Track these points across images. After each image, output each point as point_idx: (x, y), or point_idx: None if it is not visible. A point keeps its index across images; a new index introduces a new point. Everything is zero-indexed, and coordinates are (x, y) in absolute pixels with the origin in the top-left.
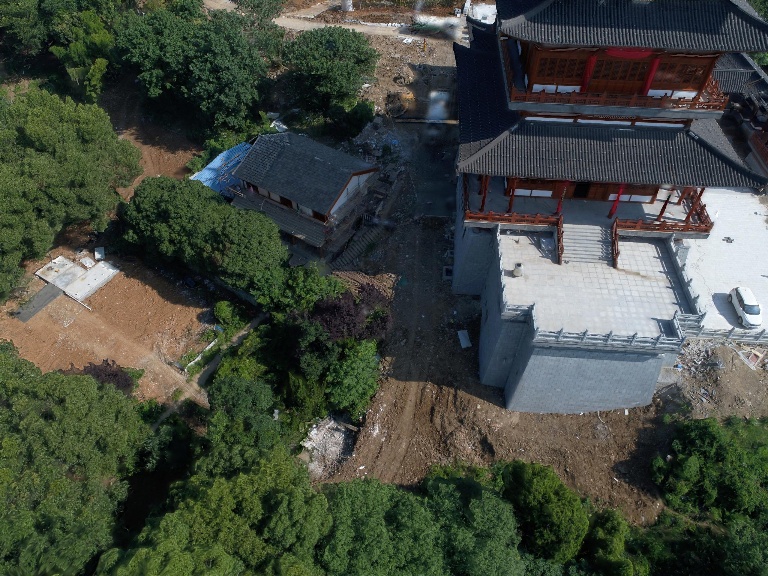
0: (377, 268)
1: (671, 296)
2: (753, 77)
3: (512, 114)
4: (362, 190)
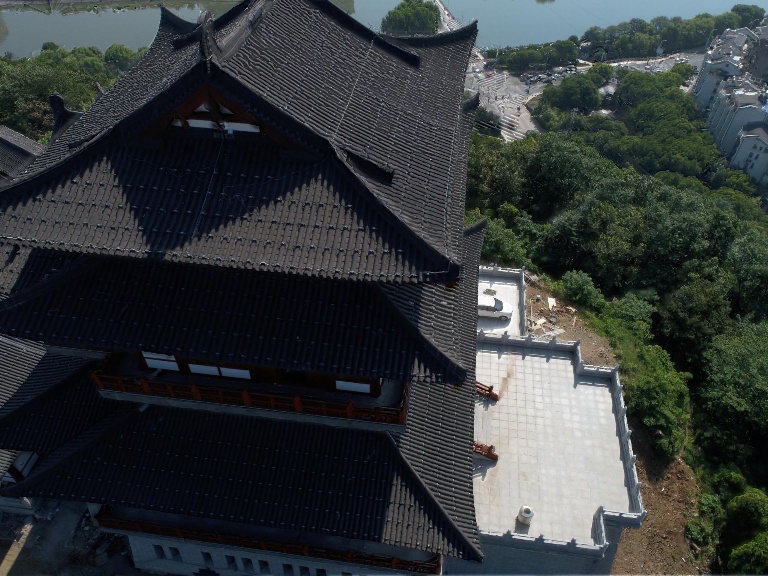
0: None
1: (537, 360)
2: None
3: (342, 434)
4: None
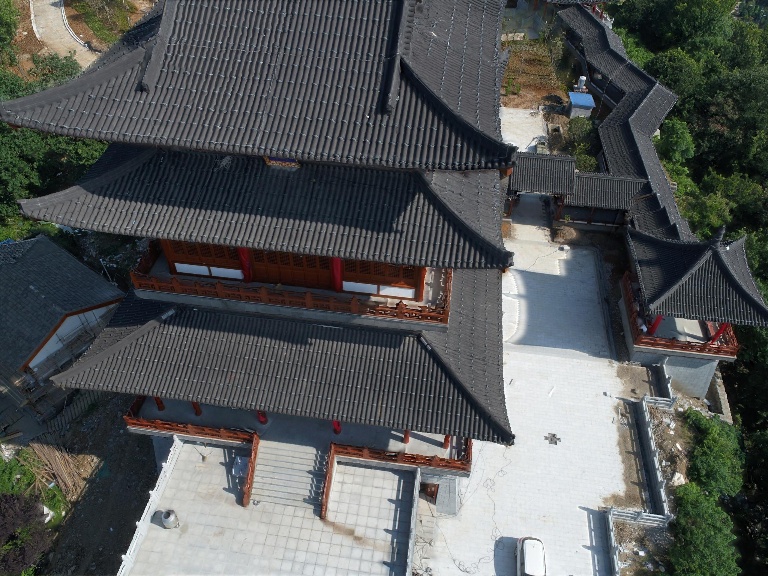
0: (84, 443)
1: None
2: (644, 189)
3: None
4: (98, 327)
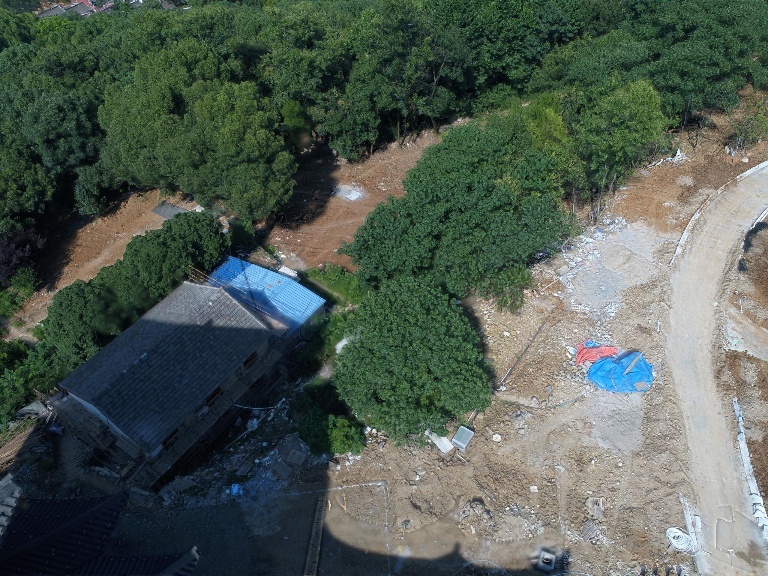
0: None
1: None
2: None
3: None
4: None
